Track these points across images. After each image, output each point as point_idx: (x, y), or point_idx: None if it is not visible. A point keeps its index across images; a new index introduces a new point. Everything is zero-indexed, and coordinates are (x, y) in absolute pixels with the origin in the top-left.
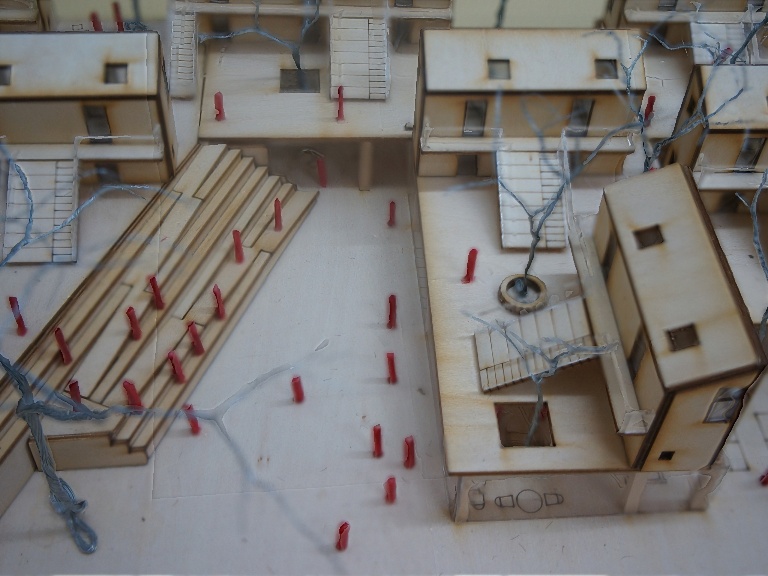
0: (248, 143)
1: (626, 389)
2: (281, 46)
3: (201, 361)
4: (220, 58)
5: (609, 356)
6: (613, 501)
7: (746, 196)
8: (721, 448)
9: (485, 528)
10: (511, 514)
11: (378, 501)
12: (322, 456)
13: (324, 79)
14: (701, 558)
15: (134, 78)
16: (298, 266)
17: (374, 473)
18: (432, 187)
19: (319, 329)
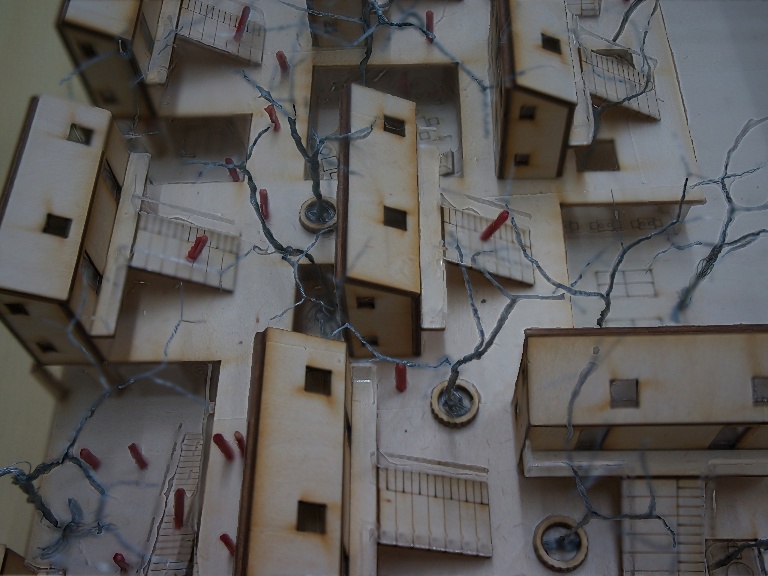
0: None
1: (748, 457)
2: None
3: None
4: None
5: None
6: None
7: None
8: None
9: None
10: None
11: None
12: None
13: None
14: None
15: None
16: None
17: None
18: None
19: None
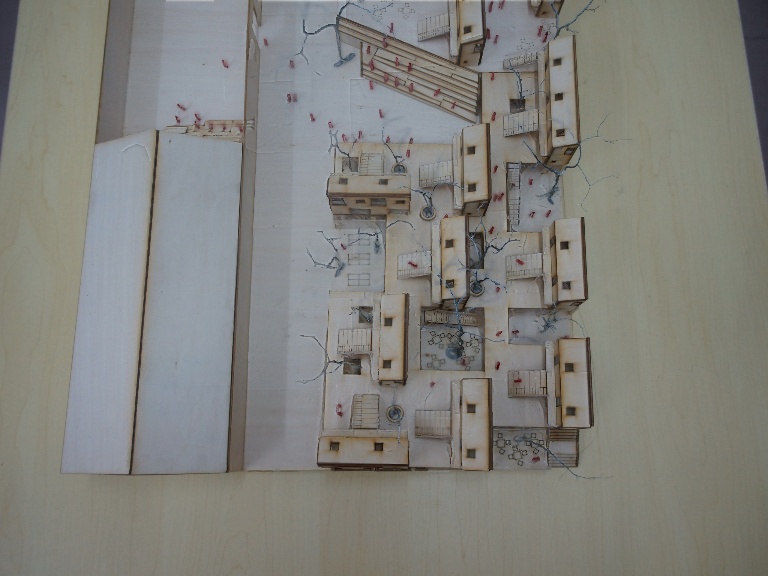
0: None
1: None
2: None
3: (394, 87)
4: (531, 77)
5: None
6: None
7: None
8: None
9: None
10: None
11: None
12: (361, 123)
13: None
14: (320, 222)
15: (466, 35)
16: (439, 117)
17: None
18: None
19: (410, 123)
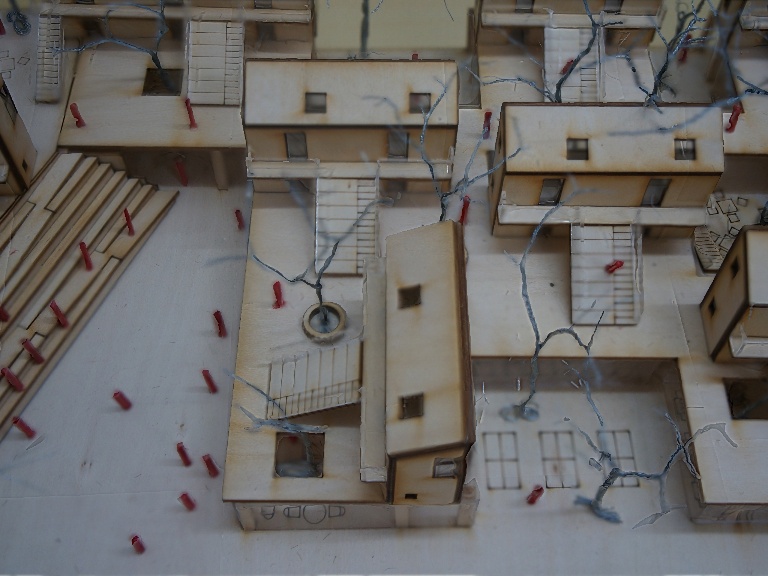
0: (104, 151)
1: (377, 437)
2: (151, 43)
3: (41, 369)
4: (91, 56)
5: (368, 404)
6: (385, 518)
7: (549, 229)
8: (461, 491)
9: (270, 537)
10: (295, 524)
11: (180, 508)
12: (138, 463)
13: (186, 81)
14: (456, 573)
15: None
16: (148, 270)
17: (182, 481)
18: (266, 204)
19: (157, 336)
